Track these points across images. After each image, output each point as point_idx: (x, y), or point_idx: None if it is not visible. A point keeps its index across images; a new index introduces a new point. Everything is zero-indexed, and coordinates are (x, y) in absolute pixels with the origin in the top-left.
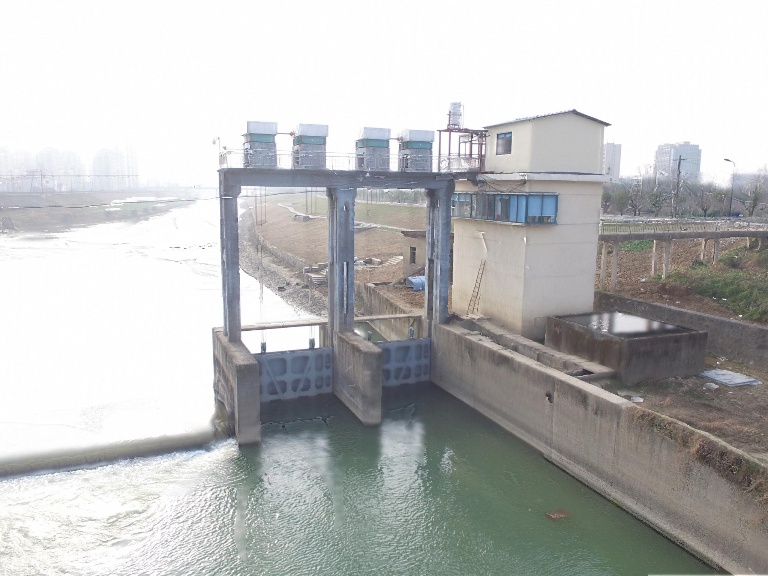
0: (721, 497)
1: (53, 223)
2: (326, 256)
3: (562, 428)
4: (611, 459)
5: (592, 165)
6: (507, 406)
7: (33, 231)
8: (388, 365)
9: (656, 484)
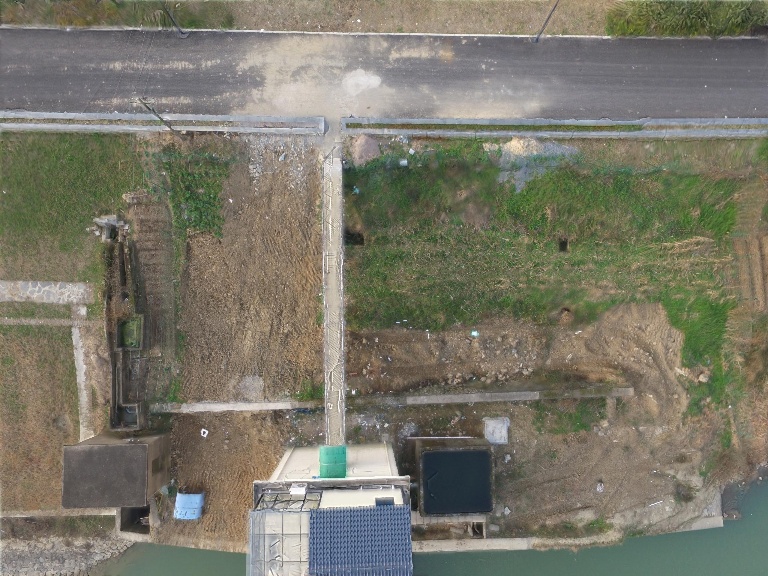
0: None
1: None
2: None
3: None
4: None
5: None
6: None
7: None
8: None
9: None
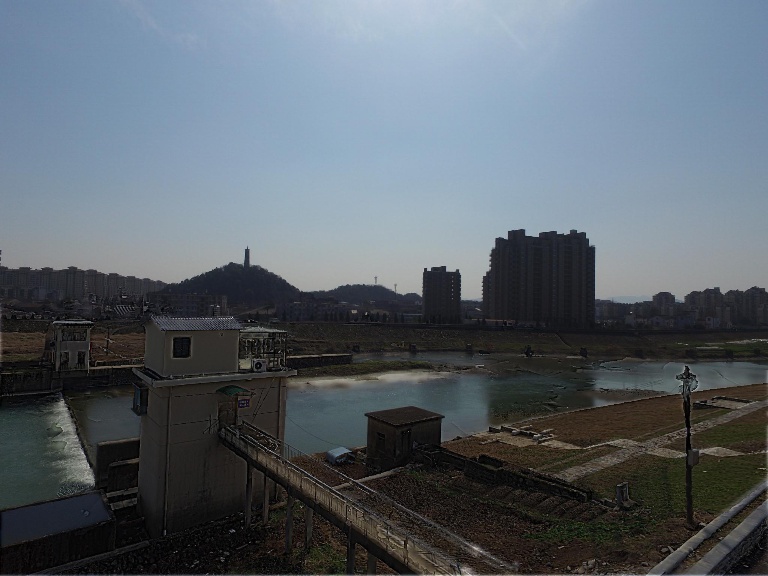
0: None
1: (623, 355)
2: (554, 423)
3: None
4: None
5: (161, 367)
6: None
7: (605, 360)
8: None
9: None
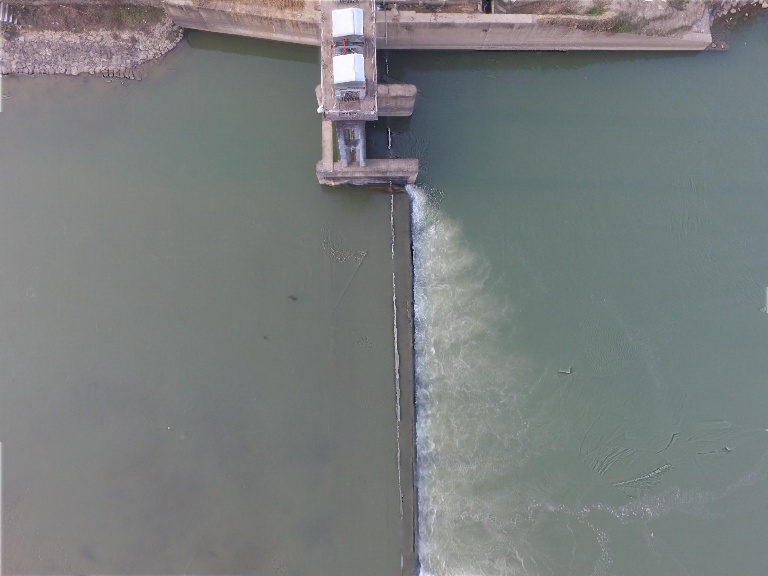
0: (579, 34)
1: None
2: None
3: None
4: None
5: None
6: None
7: None
8: None
9: None
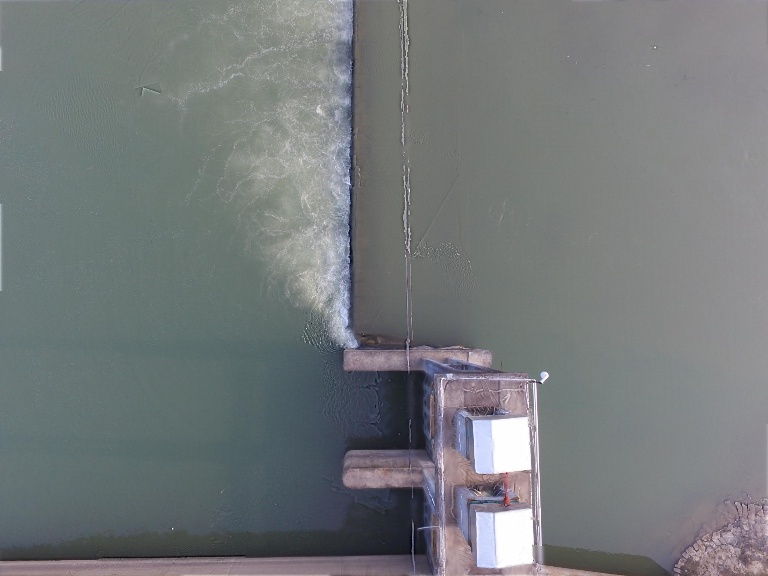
0: None
1: None
2: None
3: (218, 572)
4: (168, 572)
5: None
6: (290, 567)
7: None
8: (428, 514)
9: (129, 572)
